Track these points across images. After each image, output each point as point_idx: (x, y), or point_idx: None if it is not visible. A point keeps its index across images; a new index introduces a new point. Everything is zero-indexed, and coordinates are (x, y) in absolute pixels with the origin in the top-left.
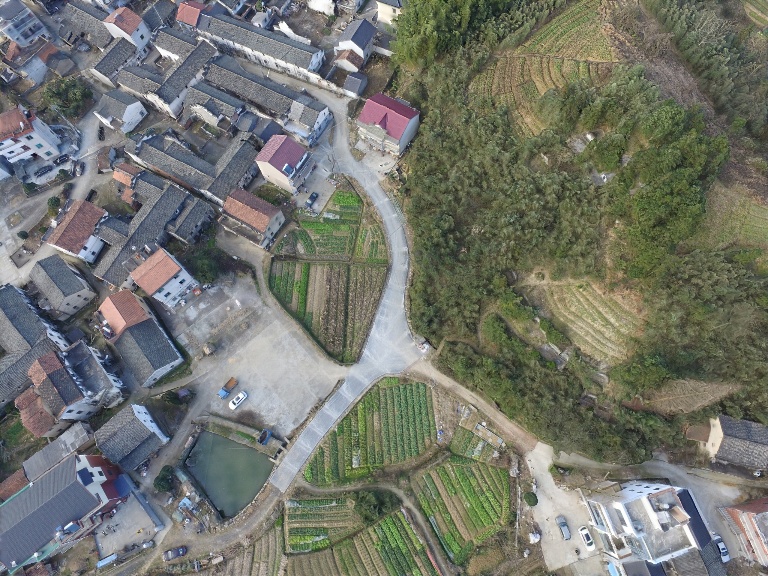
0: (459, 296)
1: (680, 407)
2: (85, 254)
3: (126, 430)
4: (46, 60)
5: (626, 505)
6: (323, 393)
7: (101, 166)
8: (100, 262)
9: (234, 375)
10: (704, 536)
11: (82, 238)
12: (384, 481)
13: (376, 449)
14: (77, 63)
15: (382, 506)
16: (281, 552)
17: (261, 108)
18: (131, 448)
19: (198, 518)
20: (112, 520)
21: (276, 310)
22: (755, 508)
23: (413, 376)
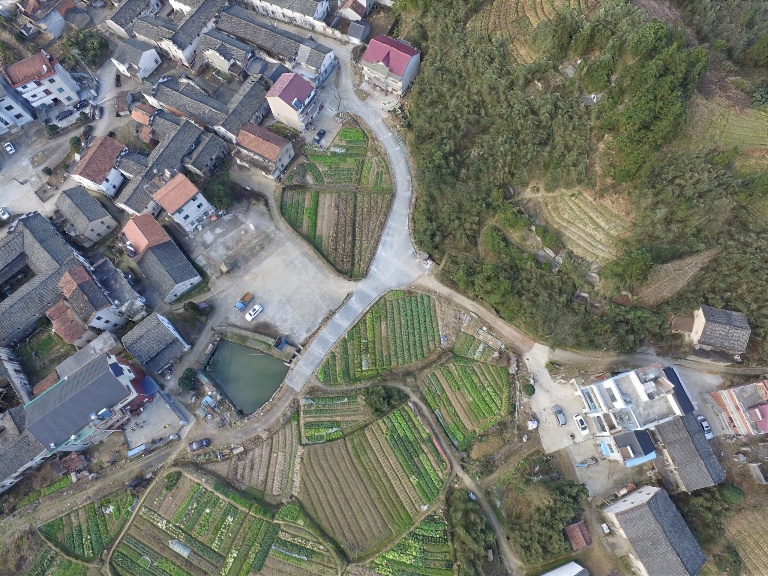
0: (460, 212)
1: (665, 292)
2: (107, 186)
3: (152, 333)
4: (64, 14)
5: (616, 382)
6: (333, 305)
7: (119, 109)
8: (121, 193)
9: (250, 291)
10: (687, 406)
11: (104, 170)
12: (392, 380)
13: (384, 353)
14: (93, 18)
15: (391, 399)
16: (297, 443)
17: (269, 54)
18: (156, 350)
19: (219, 414)
20: (139, 418)
21: (288, 233)
22: (735, 387)
23: (418, 289)
